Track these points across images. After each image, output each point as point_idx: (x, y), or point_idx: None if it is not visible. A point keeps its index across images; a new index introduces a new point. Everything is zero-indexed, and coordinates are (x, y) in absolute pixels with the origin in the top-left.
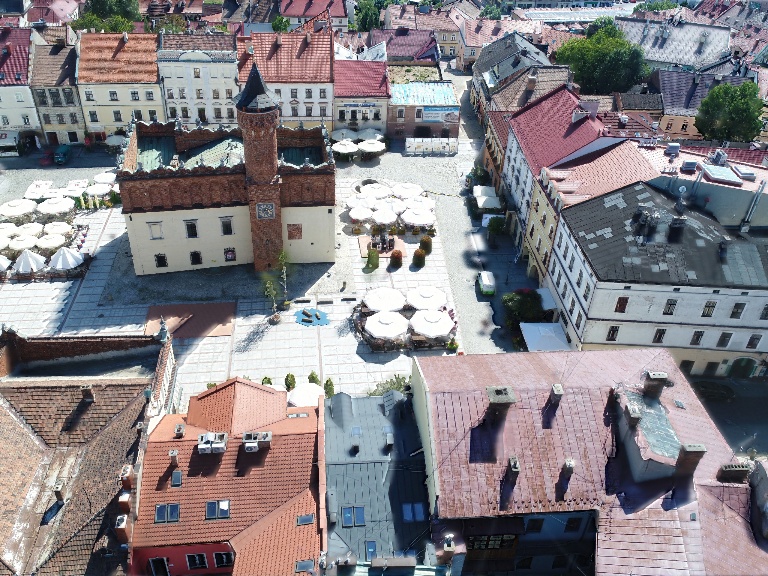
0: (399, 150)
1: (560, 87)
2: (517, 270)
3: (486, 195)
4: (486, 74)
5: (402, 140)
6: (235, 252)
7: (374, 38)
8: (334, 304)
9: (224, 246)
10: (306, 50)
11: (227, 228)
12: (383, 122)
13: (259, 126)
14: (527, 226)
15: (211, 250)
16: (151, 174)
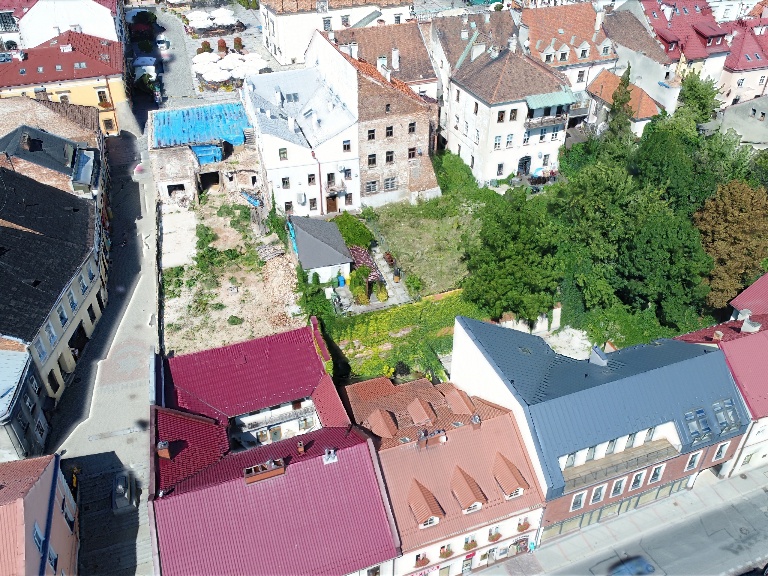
0: None
1: None
2: (138, 55)
3: None
4: (86, 177)
5: None
6: None
7: (357, 436)
8: None
9: None
10: None
11: None
12: None
13: None
14: None
15: None
16: None
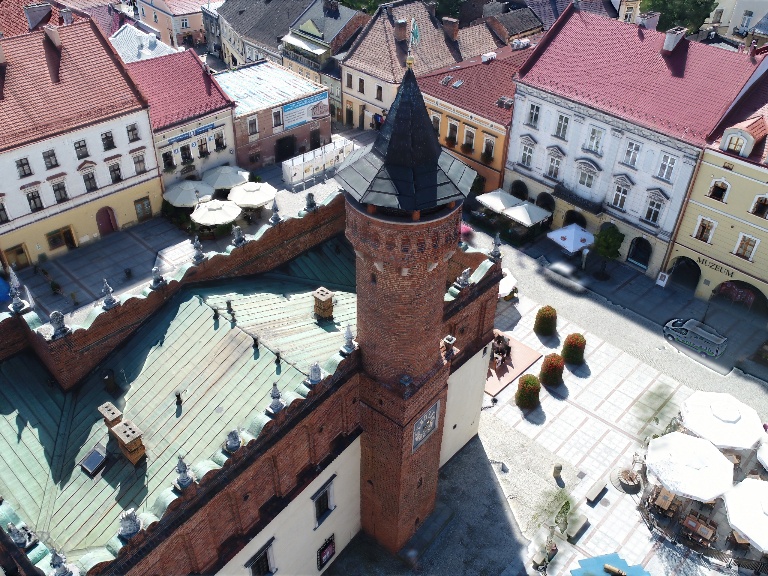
0: (277, 185)
1: (568, 10)
2: (678, 297)
3: (511, 204)
4: (290, 39)
5: (261, 169)
6: (333, 540)
7: None
8: (594, 524)
9: (316, 546)
10: (62, 62)
11: (319, 506)
12: (231, 150)
13: (450, 244)
14: (680, 227)
15: (294, 574)
16: (161, 520)
